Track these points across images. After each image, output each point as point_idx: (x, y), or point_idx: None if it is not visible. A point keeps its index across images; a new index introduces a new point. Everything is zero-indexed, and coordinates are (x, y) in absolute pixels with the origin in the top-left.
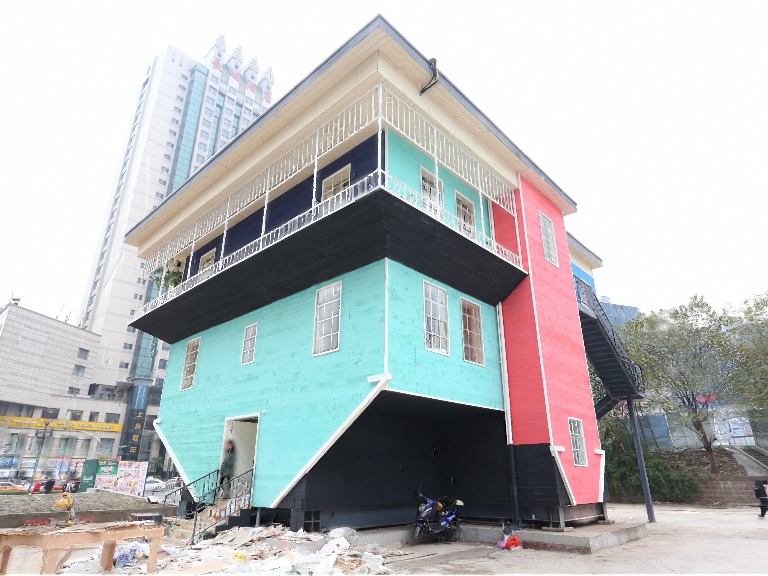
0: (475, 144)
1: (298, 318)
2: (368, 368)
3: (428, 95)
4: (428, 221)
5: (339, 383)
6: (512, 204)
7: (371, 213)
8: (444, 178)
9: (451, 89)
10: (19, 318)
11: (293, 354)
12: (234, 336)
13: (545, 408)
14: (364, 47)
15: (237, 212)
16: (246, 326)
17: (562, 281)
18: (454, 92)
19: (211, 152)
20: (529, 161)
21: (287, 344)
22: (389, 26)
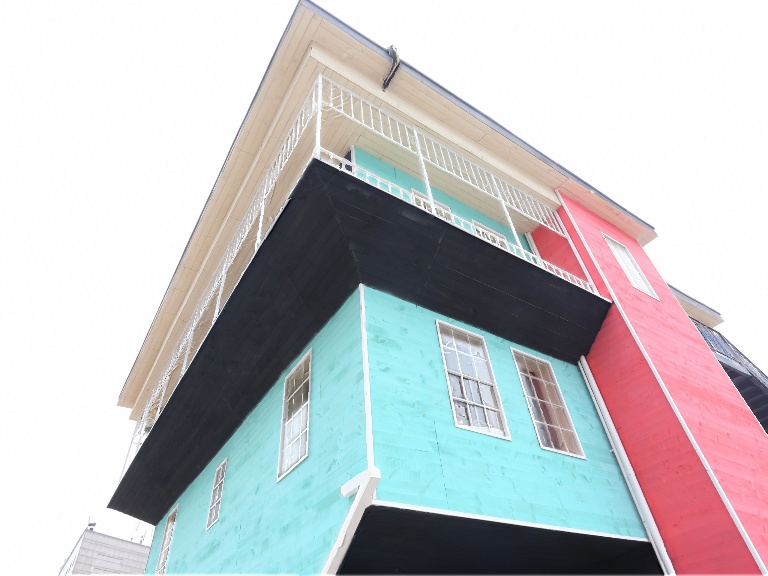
0: (480, 151)
1: (265, 429)
2: (344, 471)
3: (396, 94)
4: (415, 216)
5: (307, 516)
6: (558, 224)
7: (316, 211)
8: (452, 205)
9: (425, 81)
10: (93, 545)
11: (257, 488)
12: (205, 488)
13: (730, 519)
14: (294, 42)
15: (201, 314)
16: (217, 468)
17: (672, 318)
18: (430, 84)
19: None
20: (565, 171)
21: (252, 475)
22: (318, 8)
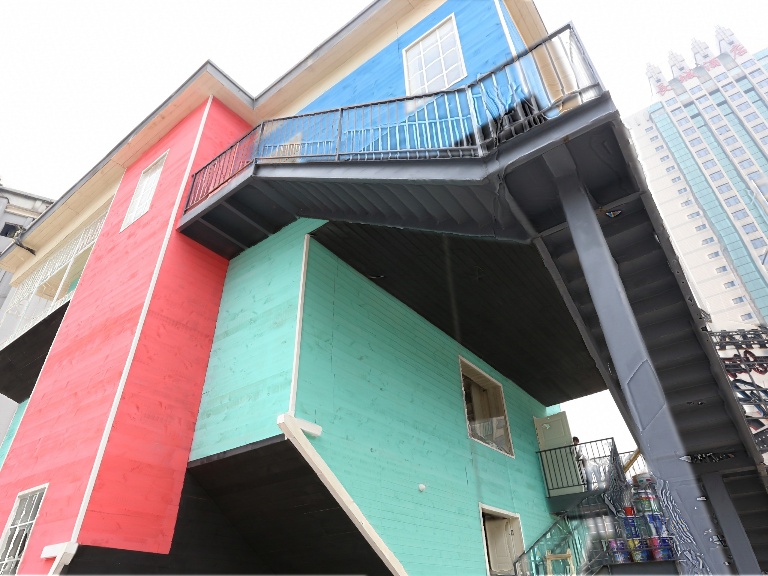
0: None
1: None
2: None
3: None
4: None
5: None
6: None
7: None
8: None
9: None
10: None
11: None
12: None
13: None
14: None
15: None
16: None
17: None
18: None
19: (724, 159)
20: None
21: None
22: None
